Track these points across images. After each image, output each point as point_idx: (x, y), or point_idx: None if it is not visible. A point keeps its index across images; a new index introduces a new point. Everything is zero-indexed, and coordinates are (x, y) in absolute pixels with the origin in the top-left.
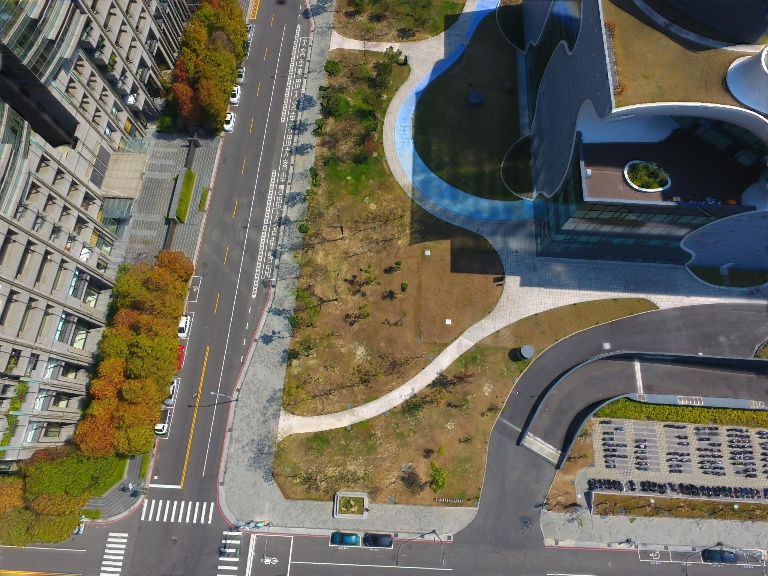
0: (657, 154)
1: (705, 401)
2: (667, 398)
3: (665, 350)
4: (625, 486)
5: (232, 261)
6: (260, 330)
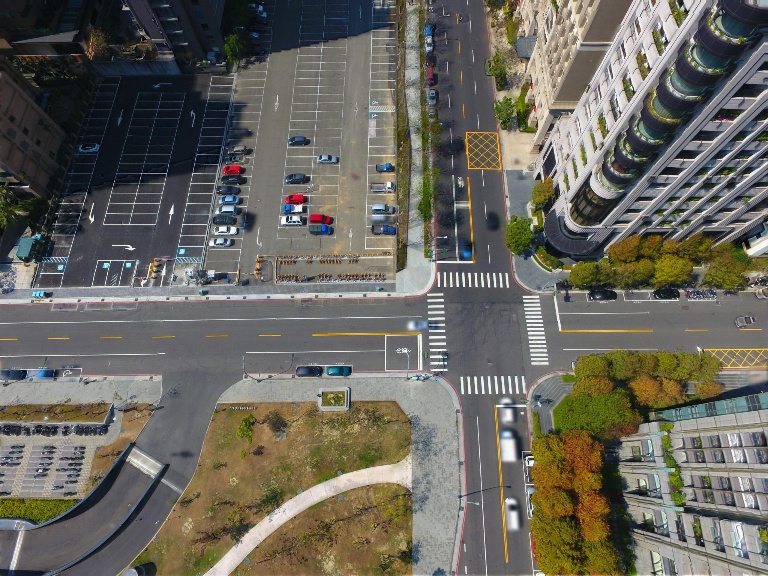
0: None
1: None
2: None
3: None
4: (73, 431)
5: None
6: None
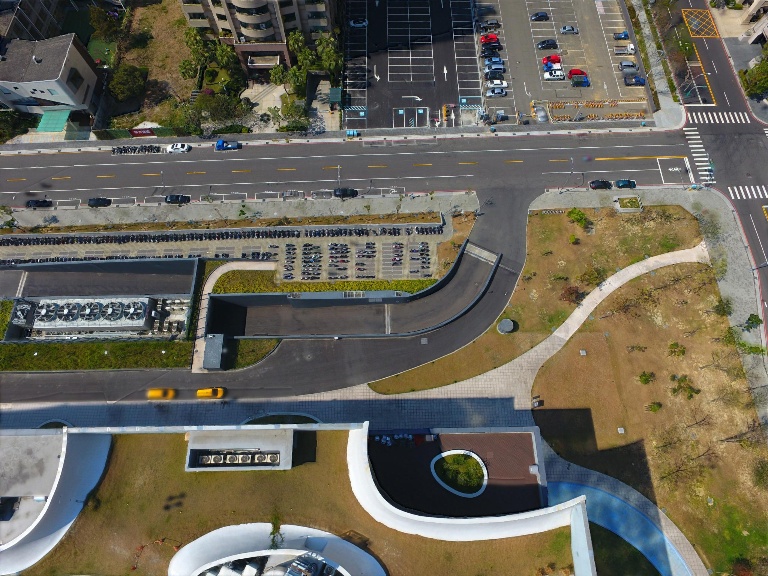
0: (443, 512)
1: (341, 295)
2: (375, 295)
3: (367, 341)
4: (413, 231)
5: None
6: (762, 332)
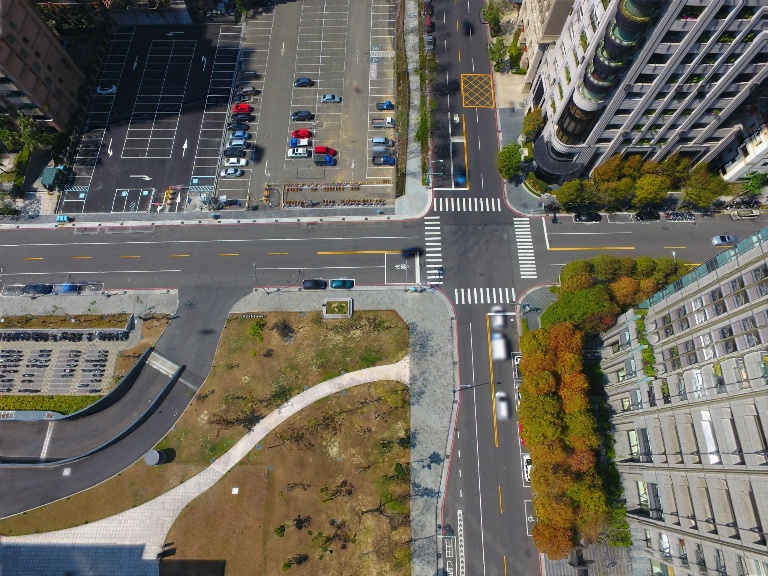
0: None
1: None
2: (24, 416)
3: (5, 471)
4: (96, 337)
5: (496, 561)
6: (445, 469)
